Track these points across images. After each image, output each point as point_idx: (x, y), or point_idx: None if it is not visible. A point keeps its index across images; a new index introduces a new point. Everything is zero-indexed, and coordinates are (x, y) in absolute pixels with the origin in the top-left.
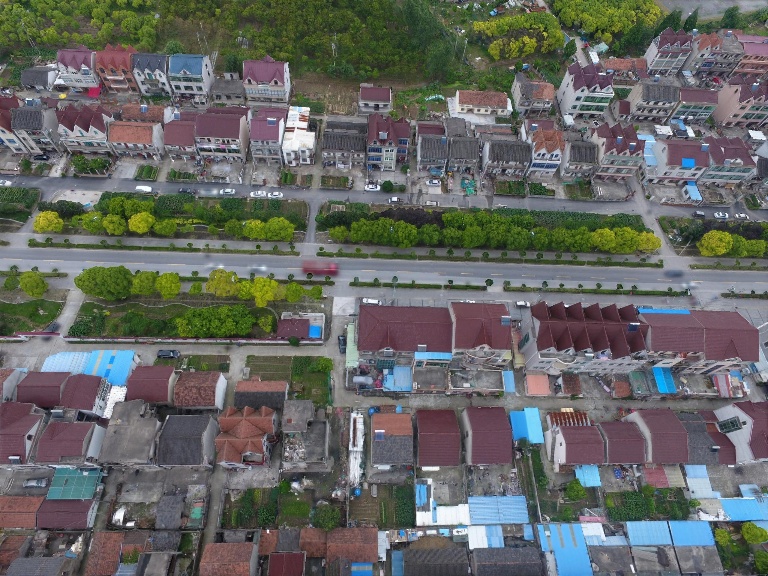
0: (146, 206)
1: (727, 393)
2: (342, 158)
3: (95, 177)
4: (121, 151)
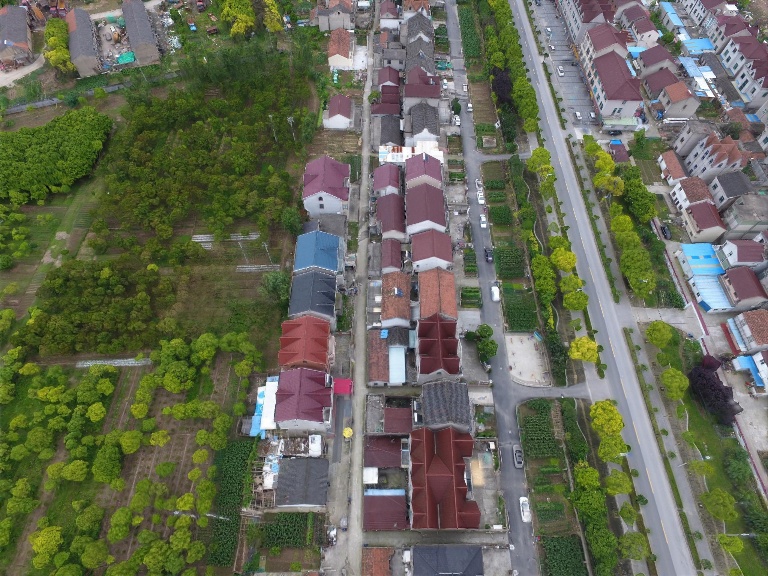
0: None
1: None
2: None
3: None
4: None
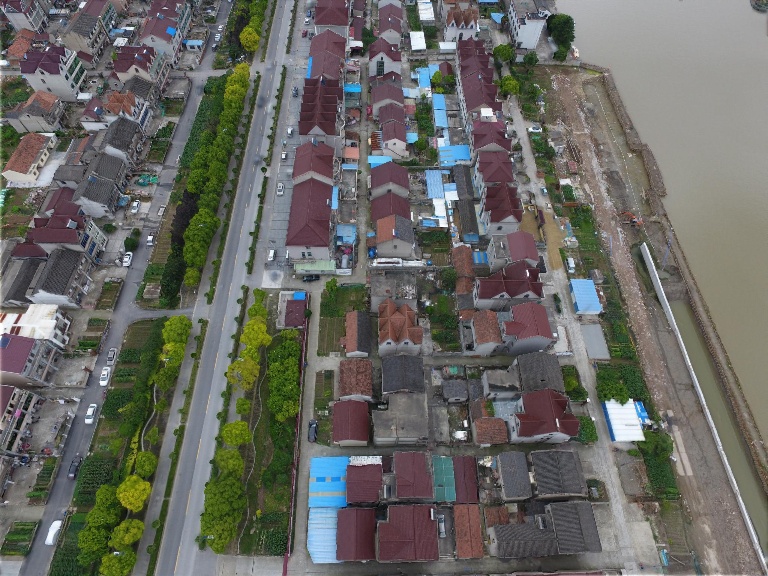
0: (106, 493)
1: (358, 68)
2: (79, 281)
3: None
4: None
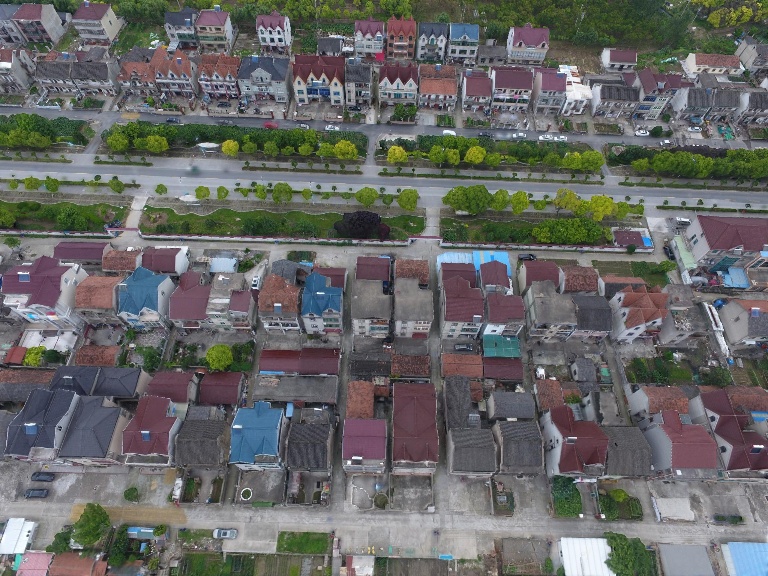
0: (475, 142)
1: None
2: (614, 108)
3: (404, 124)
4: (422, 103)
